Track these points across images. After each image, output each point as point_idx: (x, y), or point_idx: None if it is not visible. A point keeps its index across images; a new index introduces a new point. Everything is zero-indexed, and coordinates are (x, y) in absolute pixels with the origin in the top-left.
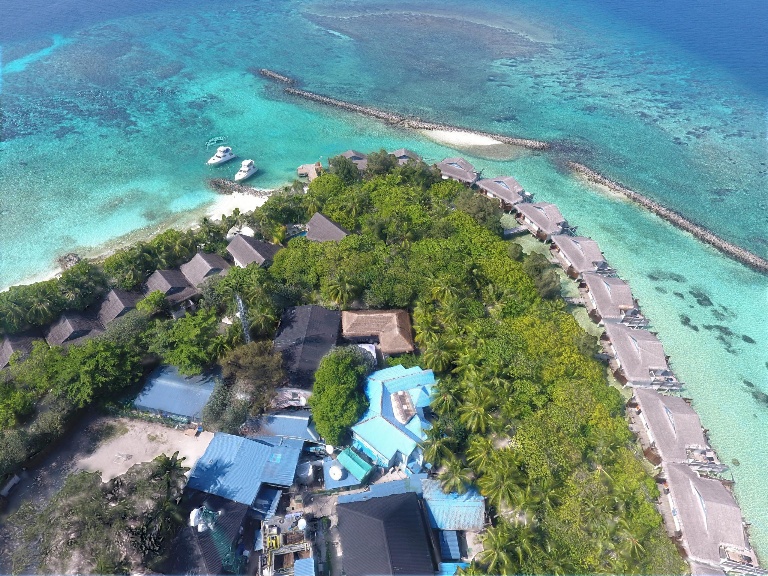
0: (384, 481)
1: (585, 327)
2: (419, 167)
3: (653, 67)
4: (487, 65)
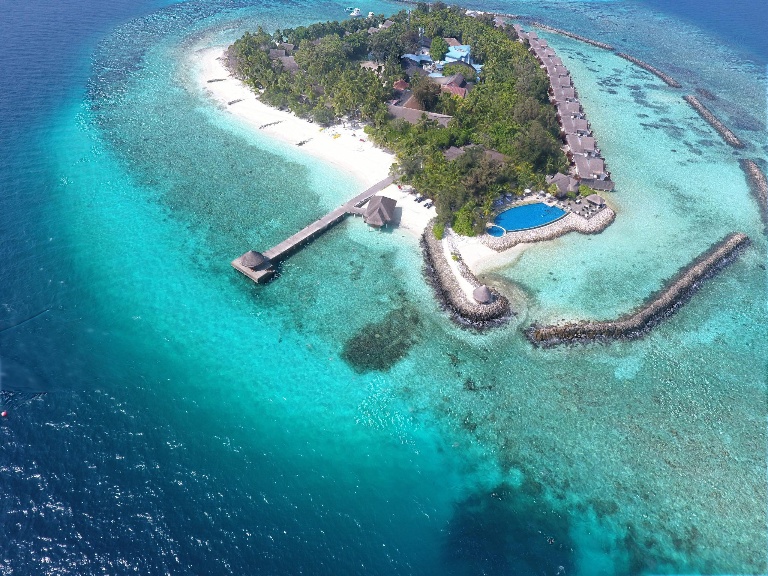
0: None
1: None
2: (457, 8)
3: None
4: None
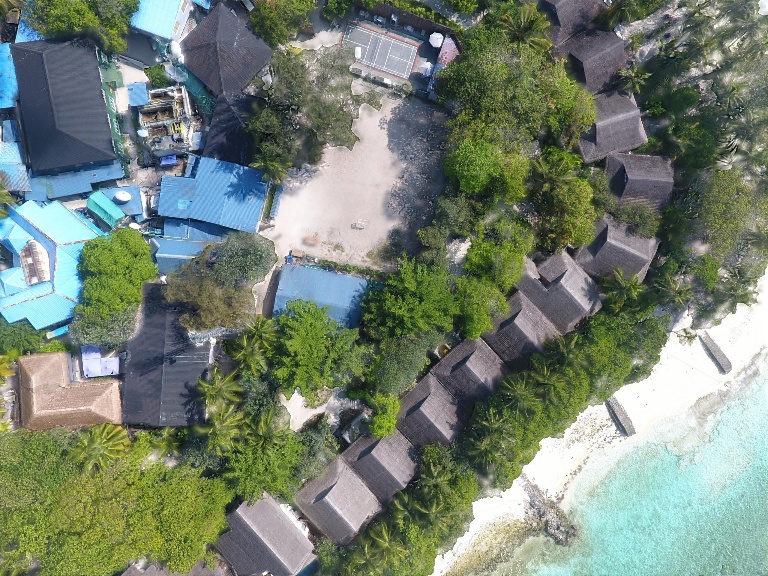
0: (83, 203)
1: None
2: None
3: None
4: None
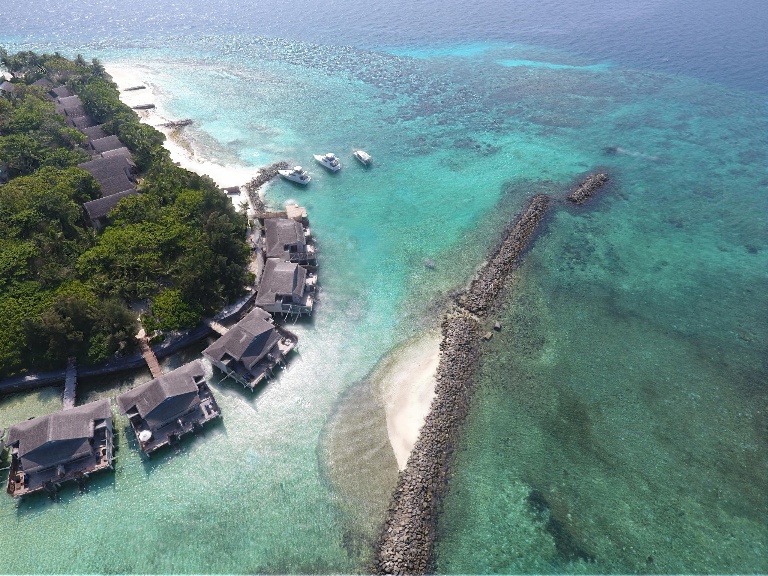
0: None
1: None
2: None
3: None
4: None
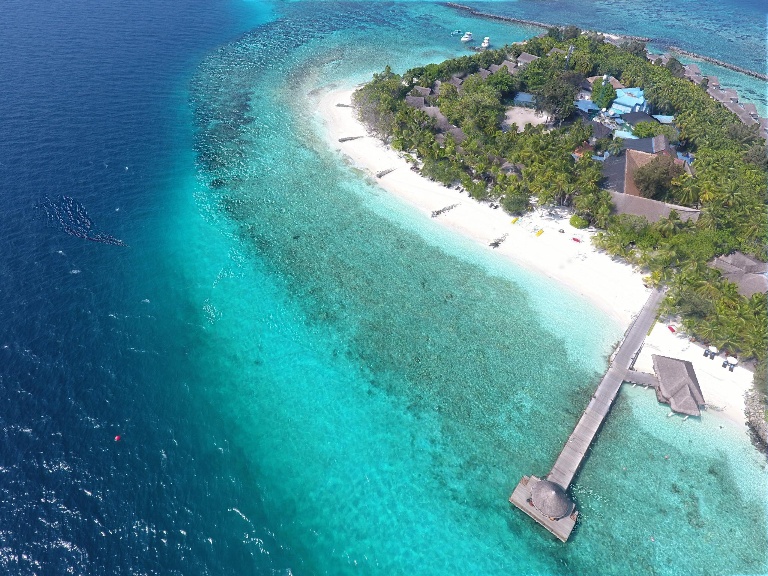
0: None
1: None
2: (594, 34)
3: (708, 7)
4: (592, 4)
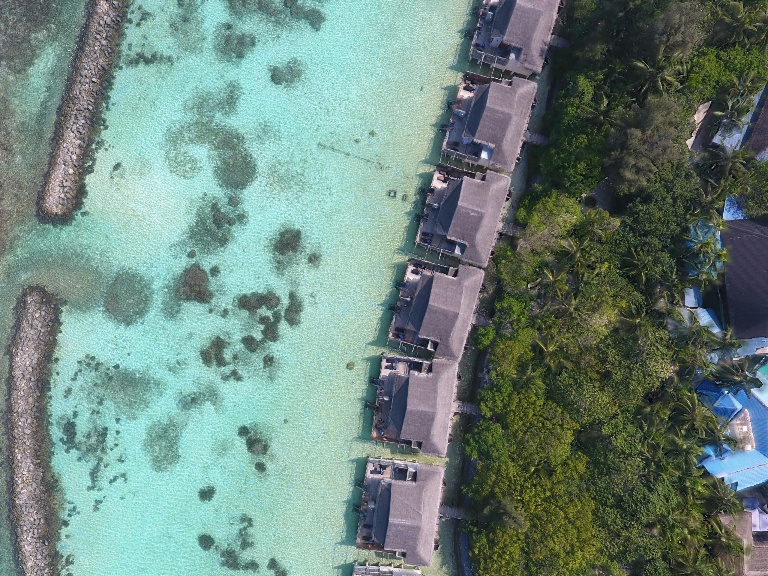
0: None
1: (436, 567)
2: None
3: None
4: None
